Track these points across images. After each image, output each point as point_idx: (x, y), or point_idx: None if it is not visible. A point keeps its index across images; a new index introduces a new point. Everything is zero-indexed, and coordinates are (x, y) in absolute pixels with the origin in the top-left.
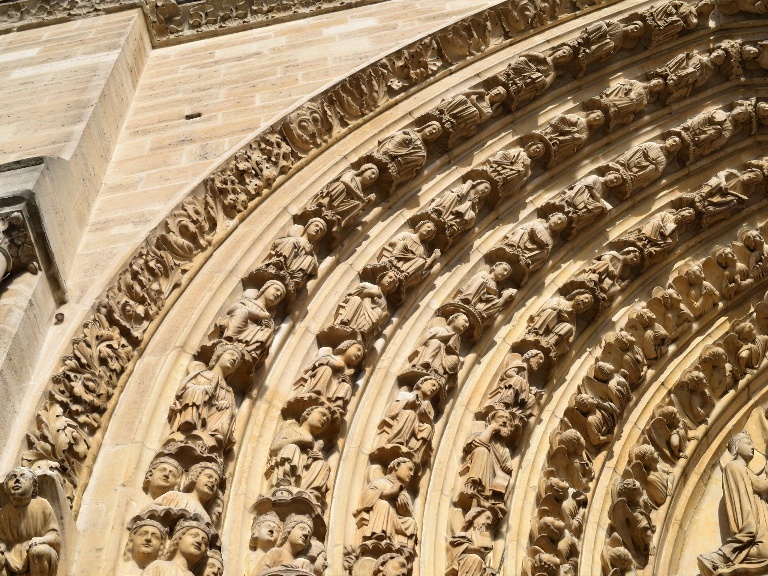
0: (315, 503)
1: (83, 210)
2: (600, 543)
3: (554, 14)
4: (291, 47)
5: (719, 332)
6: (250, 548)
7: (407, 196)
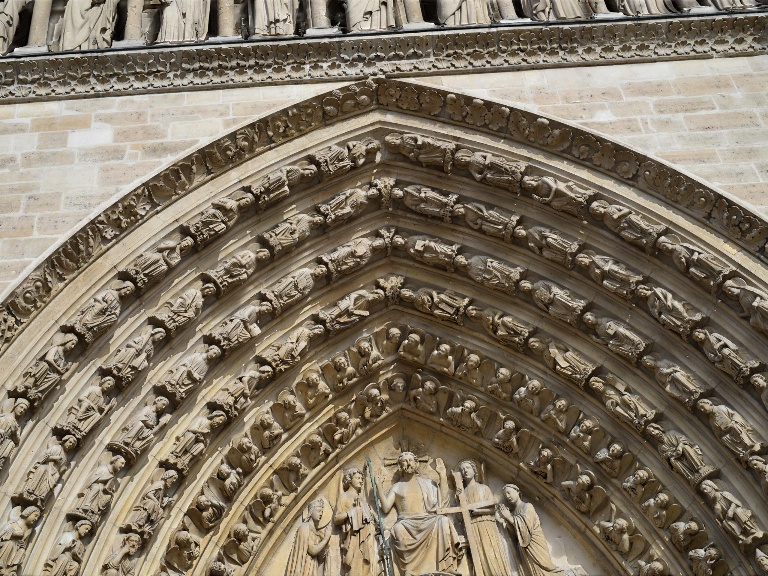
0: None
1: None
2: None
3: (252, 149)
4: (39, 159)
5: (325, 418)
6: None
7: (102, 343)
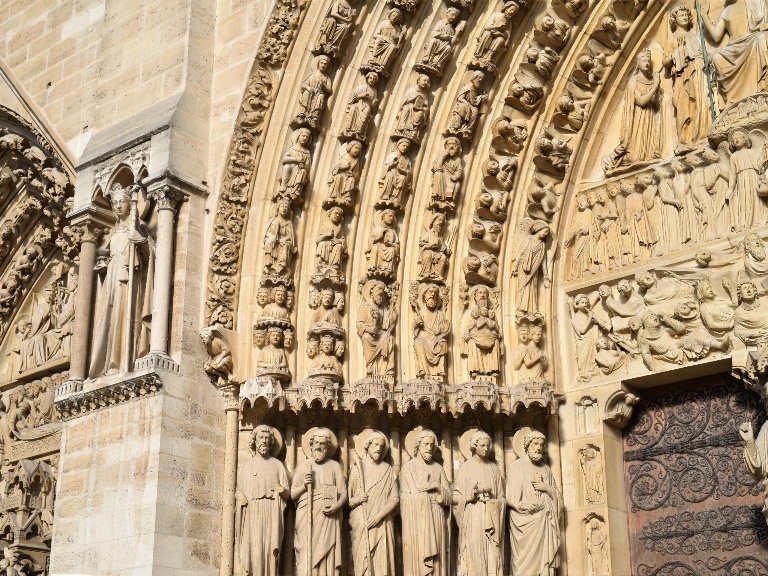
0: (334, 276)
1: (206, 103)
2: (529, 182)
3: None
4: None
5: None
6: (310, 308)
7: None
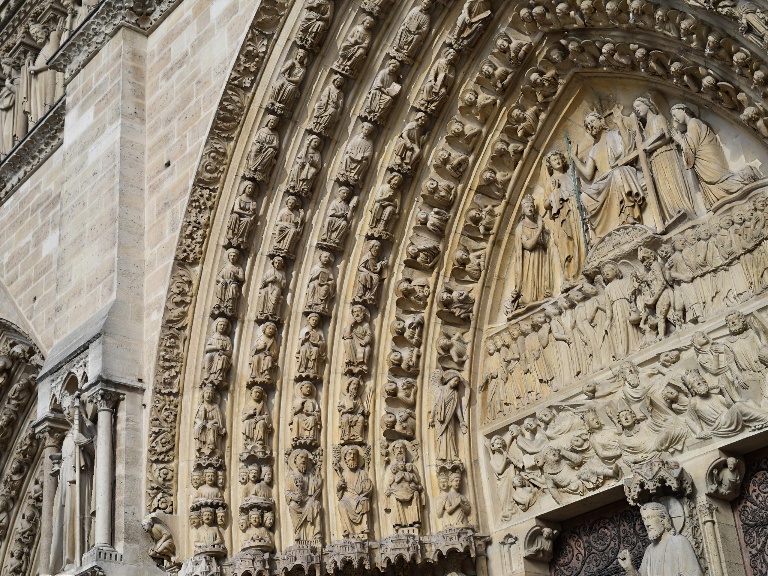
0: (258, 451)
1: (138, 306)
2: (437, 335)
3: None
4: (198, 44)
5: (503, 122)
6: (241, 484)
7: (280, 170)
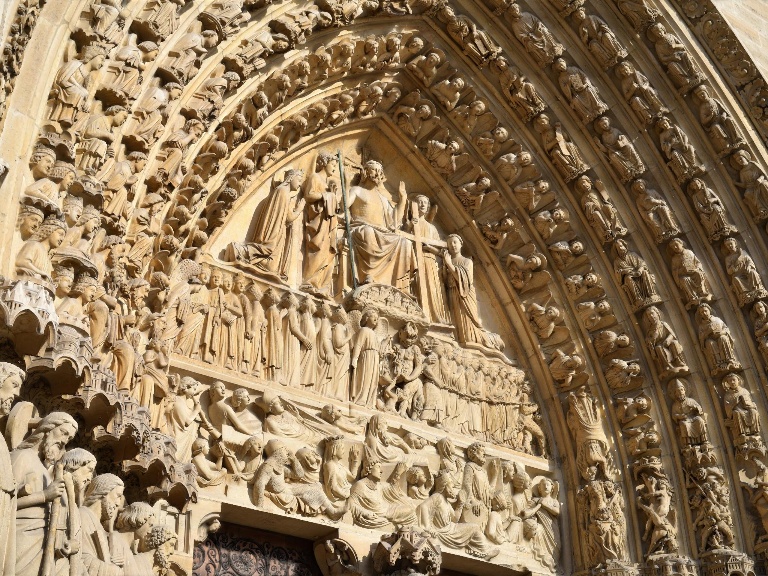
0: None
1: None
2: (194, 221)
3: None
4: None
5: (332, 92)
6: None
7: None
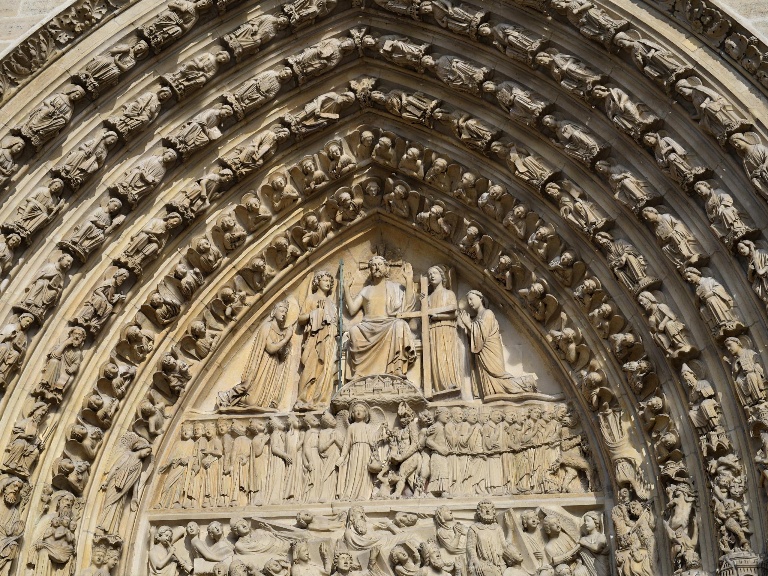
0: None
1: None
2: (141, 396)
3: None
4: None
5: (293, 221)
6: None
7: (55, 146)
